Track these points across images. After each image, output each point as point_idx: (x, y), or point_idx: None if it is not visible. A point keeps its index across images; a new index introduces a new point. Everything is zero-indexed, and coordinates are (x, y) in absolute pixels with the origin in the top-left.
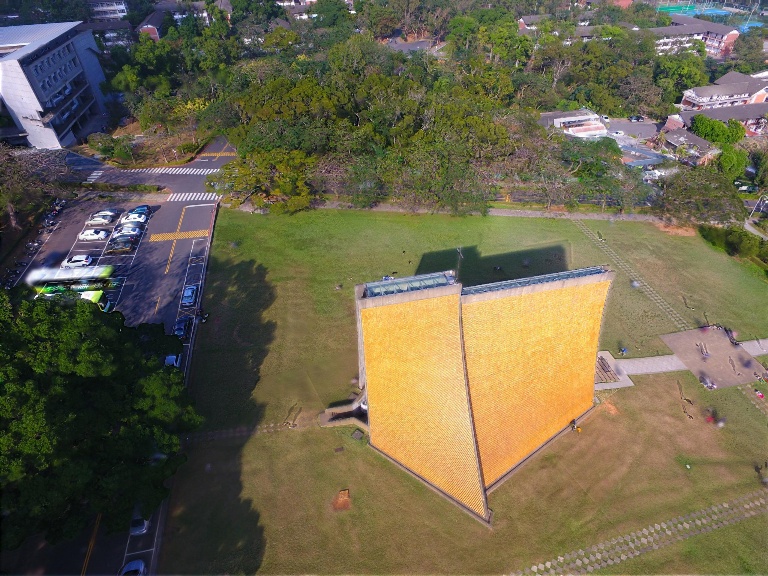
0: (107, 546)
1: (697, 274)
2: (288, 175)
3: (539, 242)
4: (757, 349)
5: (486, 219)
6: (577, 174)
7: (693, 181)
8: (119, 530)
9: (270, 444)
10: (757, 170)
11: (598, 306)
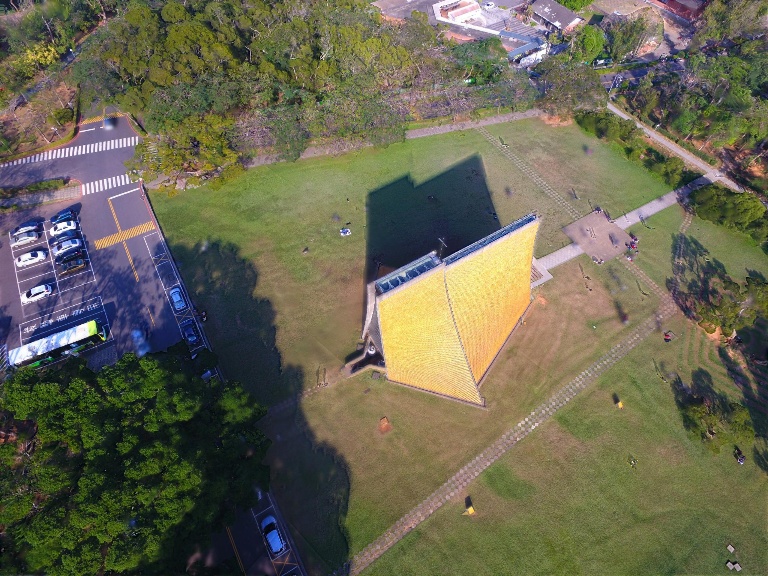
0: (237, 516)
1: (579, 164)
2: (211, 145)
3: (456, 160)
4: (625, 223)
5: (405, 145)
6: (471, 77)
7: (568, 77)
8: (252, 506)
9: (315, 404)
10: (611, 47)
11: (531, 240)
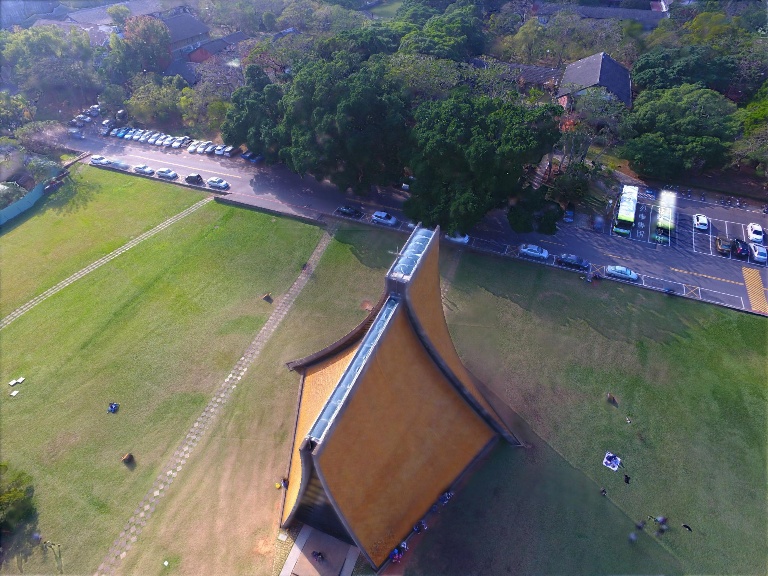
0: None
1: None
2: None
3: None
4: None
5: None
6: None
7: None
8: None
9: None
10: None
11: None
